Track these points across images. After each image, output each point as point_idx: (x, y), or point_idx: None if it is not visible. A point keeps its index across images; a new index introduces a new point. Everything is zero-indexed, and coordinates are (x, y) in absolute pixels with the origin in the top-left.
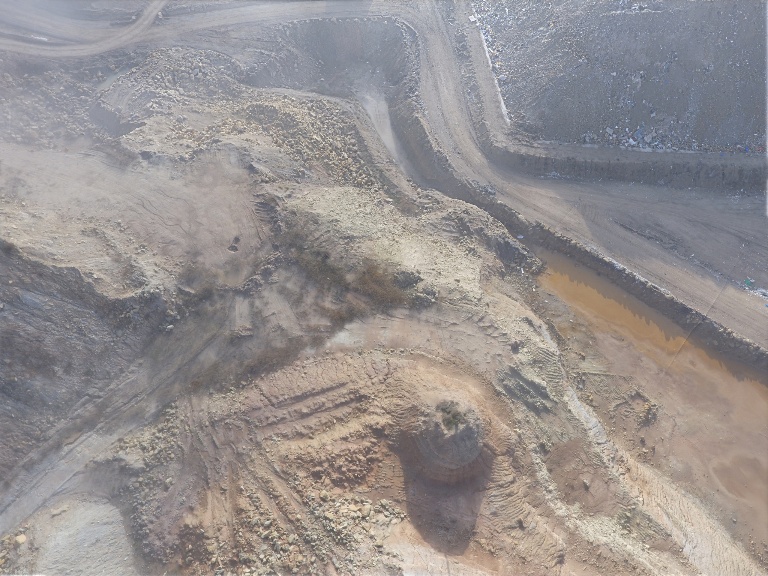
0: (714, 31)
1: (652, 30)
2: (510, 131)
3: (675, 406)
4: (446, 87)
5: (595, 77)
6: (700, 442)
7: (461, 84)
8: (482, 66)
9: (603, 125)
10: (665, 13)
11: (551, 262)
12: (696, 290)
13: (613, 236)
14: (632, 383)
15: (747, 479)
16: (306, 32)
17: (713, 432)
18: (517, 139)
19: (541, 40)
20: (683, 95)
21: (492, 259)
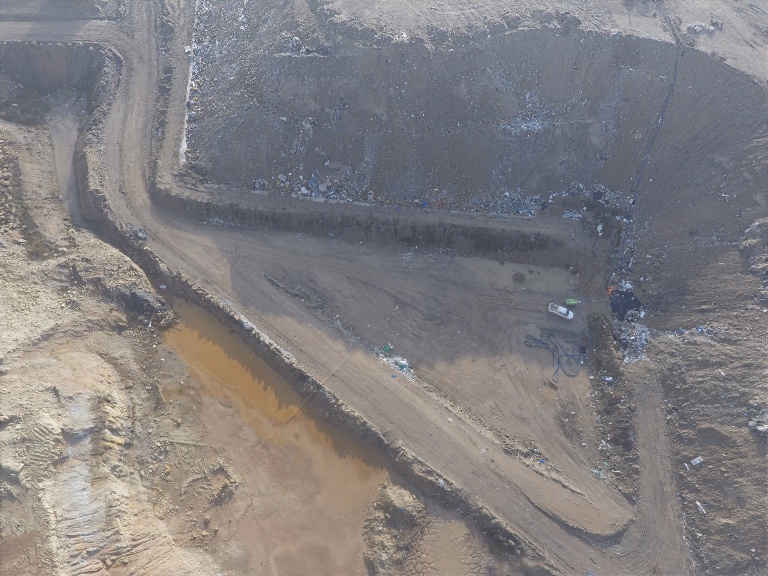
0: (384, 80)
1: (319, 75)
2: (179, 172)
3: (259, 484)
4: (135, 121)
5: (264, 121)
6: (271, 526)
7: (153, 118)
8: (178, 100)
9: (275, 171)
10: (332, 58)
11: (186, 316)
12: (322, 355)
13: (255, 291)
14: (221, 456)
15: (308, 570)
16: (4, 54)
17: (290, 515)
18: (183, 181)
19: (229, 77)
20: (357, 144)
21: (104, 312)
